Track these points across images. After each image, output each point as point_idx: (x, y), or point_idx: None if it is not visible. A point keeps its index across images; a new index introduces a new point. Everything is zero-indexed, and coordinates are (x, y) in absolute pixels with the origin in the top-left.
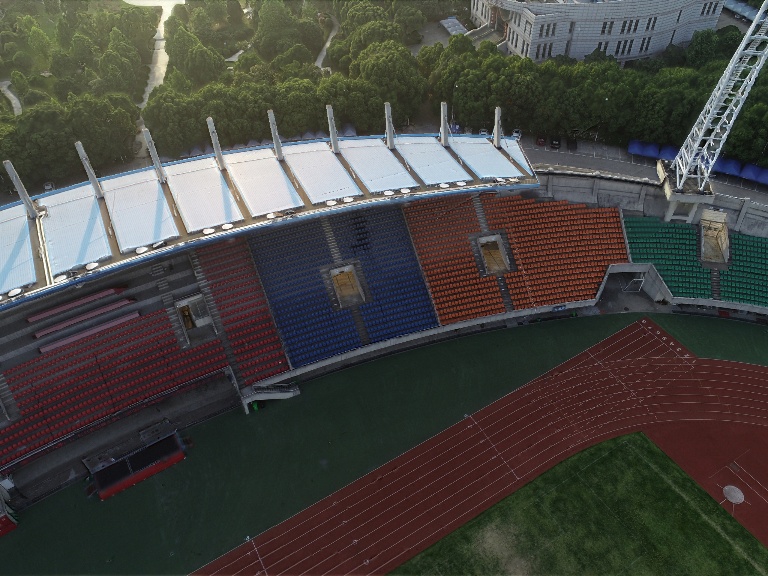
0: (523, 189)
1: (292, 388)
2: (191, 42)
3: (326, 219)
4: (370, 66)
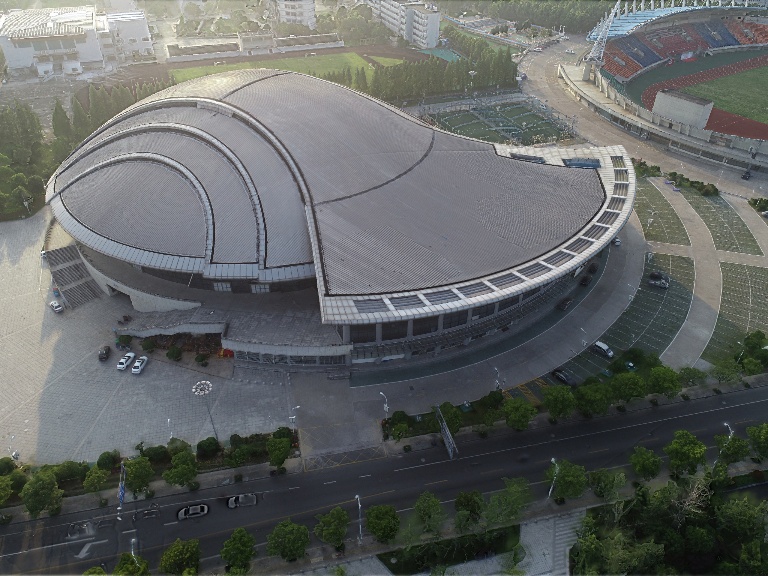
0: (751, 22)
1: None
2: (596, 1)
3: (705, 23)
4: (678, 2)
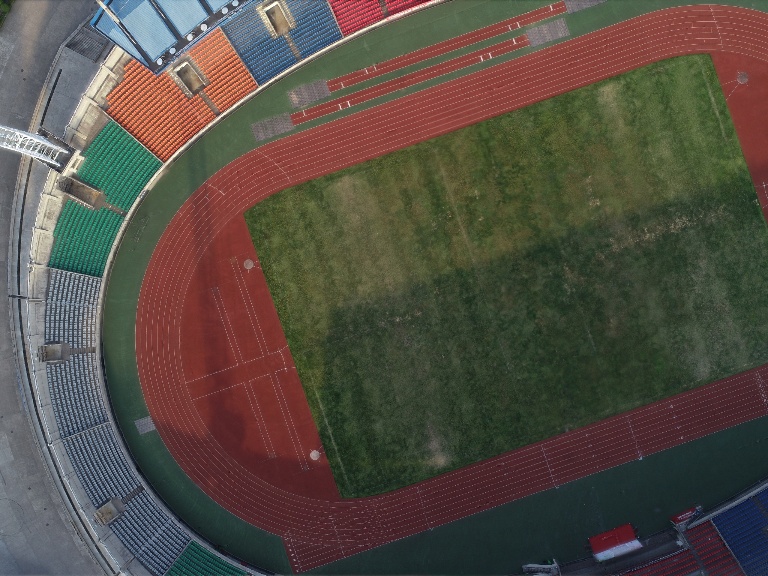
0: None
1: (527, 571)
2: None
3: None
4: None
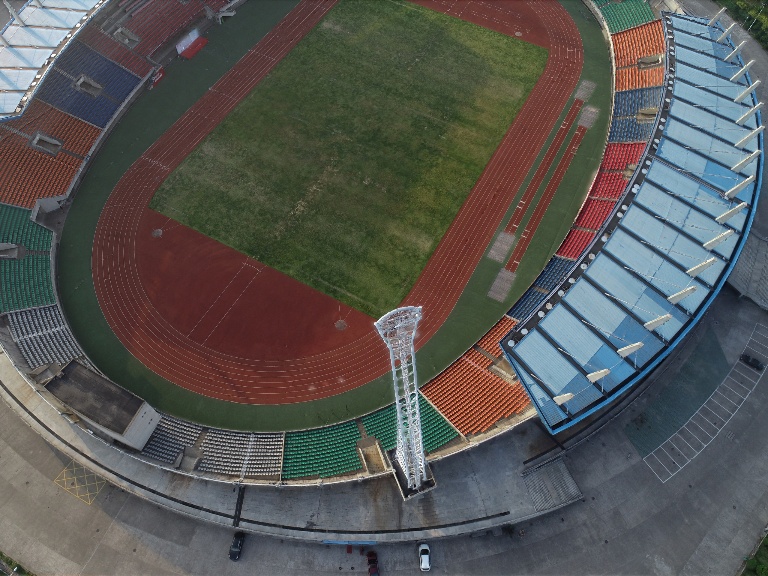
0: None
1: None
2: None
3: None
4: None
